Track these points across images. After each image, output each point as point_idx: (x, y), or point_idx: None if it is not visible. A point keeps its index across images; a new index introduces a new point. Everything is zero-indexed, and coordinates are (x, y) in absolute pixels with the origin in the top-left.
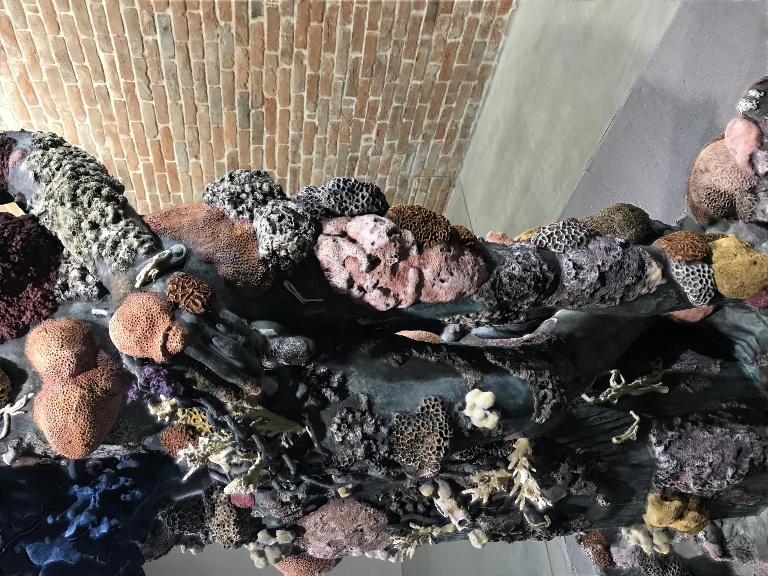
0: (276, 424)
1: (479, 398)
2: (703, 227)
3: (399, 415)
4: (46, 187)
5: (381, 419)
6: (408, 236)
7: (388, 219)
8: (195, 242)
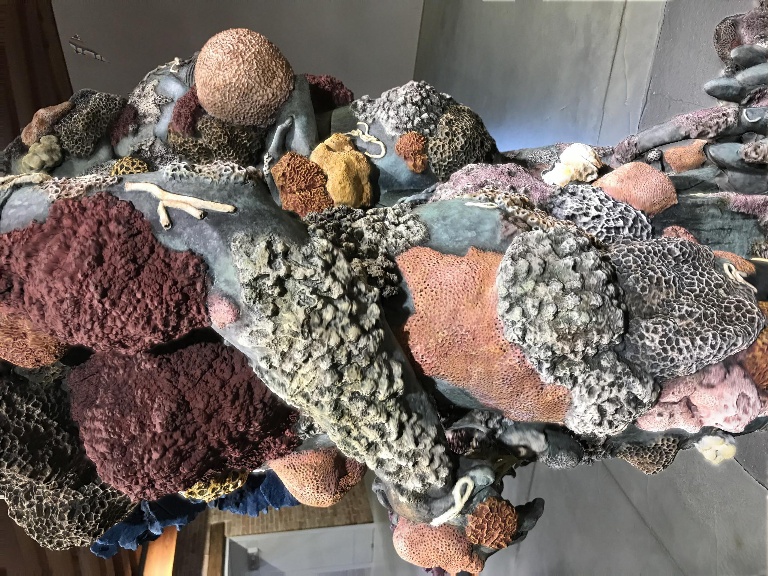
0: (510, 464)
1: (719, 447)
2: None
3: (630, 447)
4: (291, 384)
5: (611, 449)
6: (767, 411)
7: (755, 395)
8: (484, 395)
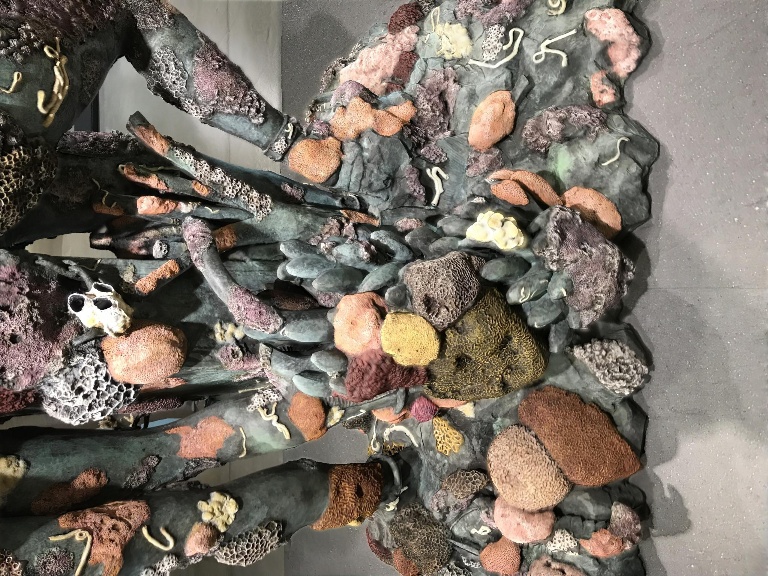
0: None
1: None
2: (540, 382)
3: None
4: None
5: None
6: None
7: None
8: None
